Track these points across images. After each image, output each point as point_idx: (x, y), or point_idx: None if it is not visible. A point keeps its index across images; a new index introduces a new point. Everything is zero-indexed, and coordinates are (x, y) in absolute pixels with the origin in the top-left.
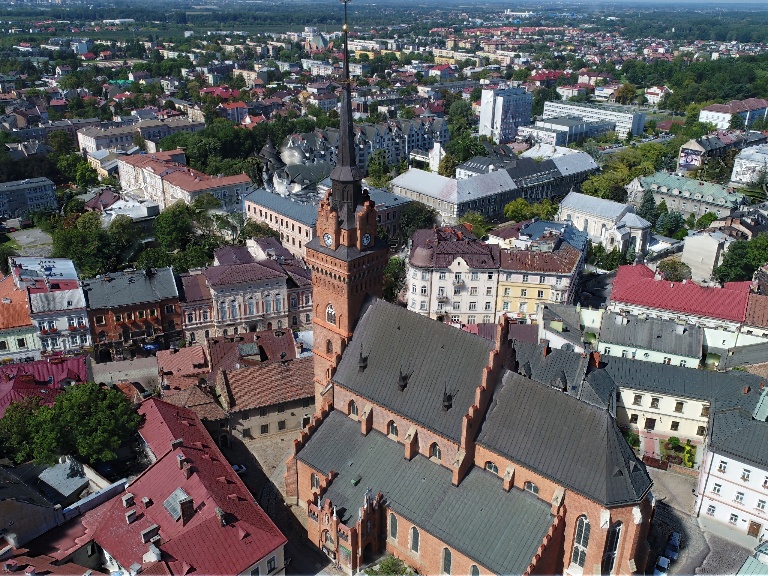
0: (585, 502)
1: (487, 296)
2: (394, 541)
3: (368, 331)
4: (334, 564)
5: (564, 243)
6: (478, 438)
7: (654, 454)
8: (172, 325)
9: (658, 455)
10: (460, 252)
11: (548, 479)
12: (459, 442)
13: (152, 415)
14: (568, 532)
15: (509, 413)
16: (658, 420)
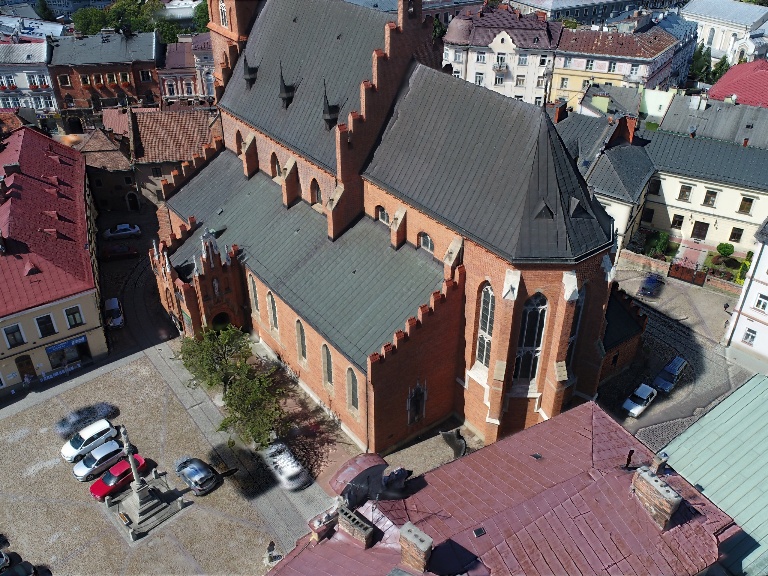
0: (488, 258)
1: (537, 88)
2: (258, 315)
3: (263, 31)
4: (181, 337)
5: (656, 27)
6: (366, 170)
7: (687, 261)
8: (150, 97)
9: (692, 262)
10: (506, 26)
11: (442, 224)
12: (336, 172)
13: (13, 143)
14: (468, 311)
15: (410, 129)
16: (712, 225)
